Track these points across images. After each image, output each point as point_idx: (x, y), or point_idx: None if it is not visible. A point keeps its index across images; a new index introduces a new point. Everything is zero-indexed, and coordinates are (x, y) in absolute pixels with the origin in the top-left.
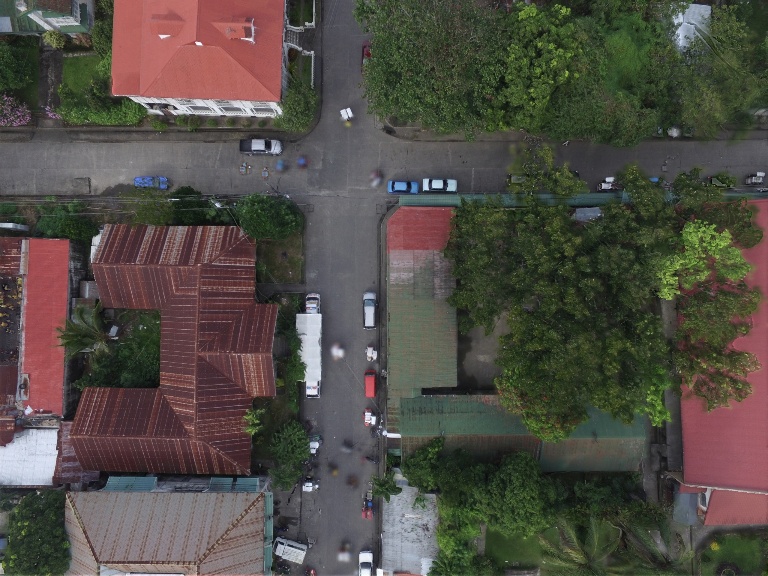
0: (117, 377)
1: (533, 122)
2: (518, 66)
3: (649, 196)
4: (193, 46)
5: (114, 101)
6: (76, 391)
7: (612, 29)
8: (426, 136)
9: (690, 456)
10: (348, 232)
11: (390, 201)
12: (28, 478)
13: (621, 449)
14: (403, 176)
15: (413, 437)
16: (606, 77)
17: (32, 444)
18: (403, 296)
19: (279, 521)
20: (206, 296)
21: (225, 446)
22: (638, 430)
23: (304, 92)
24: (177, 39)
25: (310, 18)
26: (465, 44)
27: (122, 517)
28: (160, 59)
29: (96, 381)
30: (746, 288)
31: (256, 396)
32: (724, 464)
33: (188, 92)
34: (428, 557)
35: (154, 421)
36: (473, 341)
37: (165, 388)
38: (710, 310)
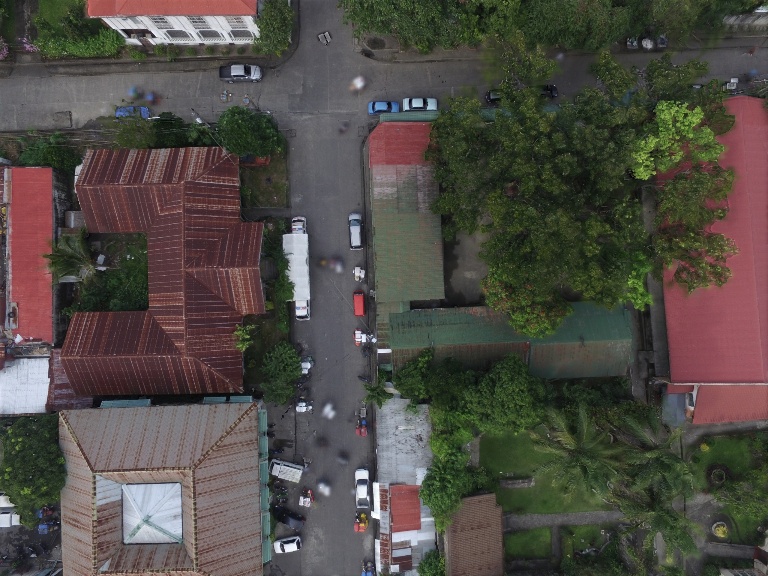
0: (106, 307)
1: (507, 23)
2: None
3: (622, 77)
4: None
5: (91, 31)
6: (66, 322)
7: None
8: (404, 57)
9: (676, 355)
10: (331, 155)
11: (371, 123)
12: (21, 407)
13: (608, 352)
14: (383, 98)
15: (403, 349)
16: None
17: (23, 373)
18: (387, 210)
19: (274, 444)
20: (191, 213)
21: (216, 363)
22: (624, 332)
23: (280, 7)
24: None
25: None
26: None
27: (116, 430)
28: None
29: (85, 309)
30: (721, 169)
31: (245, 314)
32: (709, 360)
33: (164, 8)
34: (423, 467)
35: (144, 340)
36: (459, 258)
37: (154, 309)
38: (685, 186)
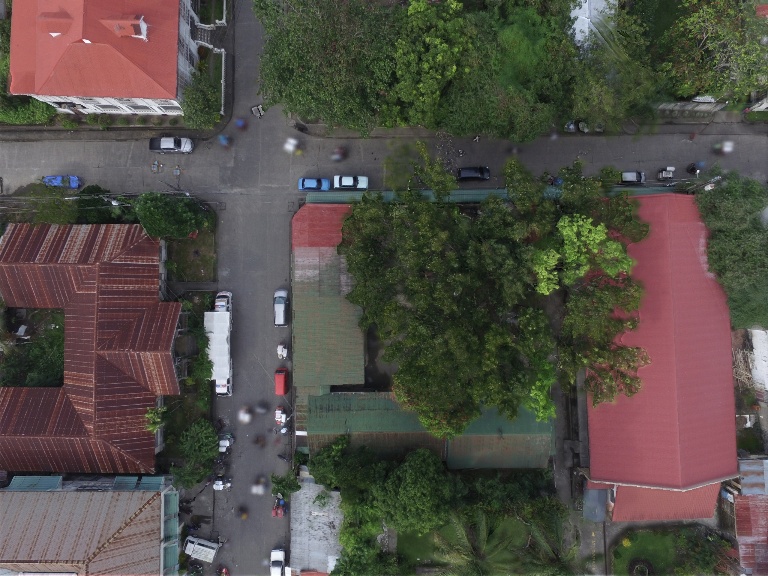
0: None
1: (425, 117)
2: (407, 61)
3: (525, 190)
4: (82, 44)
5: (22, 100)
6: None
7: (507, 24)
8: (338, 133)
9: (596, 452)
10: (260, 230)
11: (302, 198)
12: None
13: (528, 445)
14: (315, 173)
15: (319, 435)
16: (500, 72)
17: None
18: (308, 293)
19: (192, 520)
20: (105, 294)
21: (127, 445)
22: (544, 426)
23: (203, 89)
24: (66, 37)
25: (221, 16)
26: (351, 40)
27: (15, 516)
28: (52, 57)
29: (3, 381)
30: (629, 282)
31: (160, 394)
32: (628, 460)
33: (83, 90)
34: (334, 555)
35: (55, 420)
36: None
37: (68, 387)
38: (586, 304)
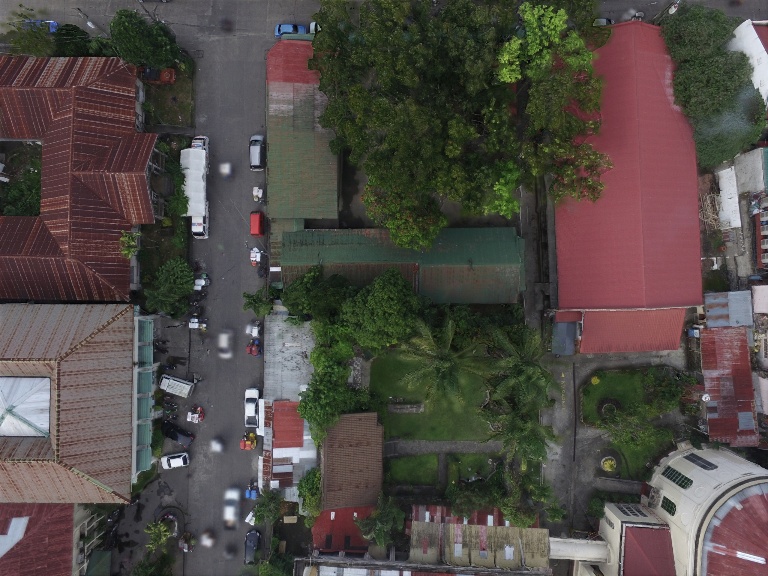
0: None
1: None
2: None
3: None
4: None
5: None
6: None
7: None
8: None
9: (564, 282)
10: (237, 77)
11: None
12: None
13: (498, 278)
14: (291, 22)
15: (292, 266)
16: None
17: None
18: (282, 127)
19: (168, 361)
20: (81, 118)
21: (102, 268)
22: (513, 258)
23: None
24: None
25: None
26: None
27: None
28: None
29: None
30: (590, 78)
31: (135, 223)
32: (595, 286)
33: None
34: (306, 384)
35: (31, 243)
36: (360, 184)
37: (44, 214)
38: (546, 88)
